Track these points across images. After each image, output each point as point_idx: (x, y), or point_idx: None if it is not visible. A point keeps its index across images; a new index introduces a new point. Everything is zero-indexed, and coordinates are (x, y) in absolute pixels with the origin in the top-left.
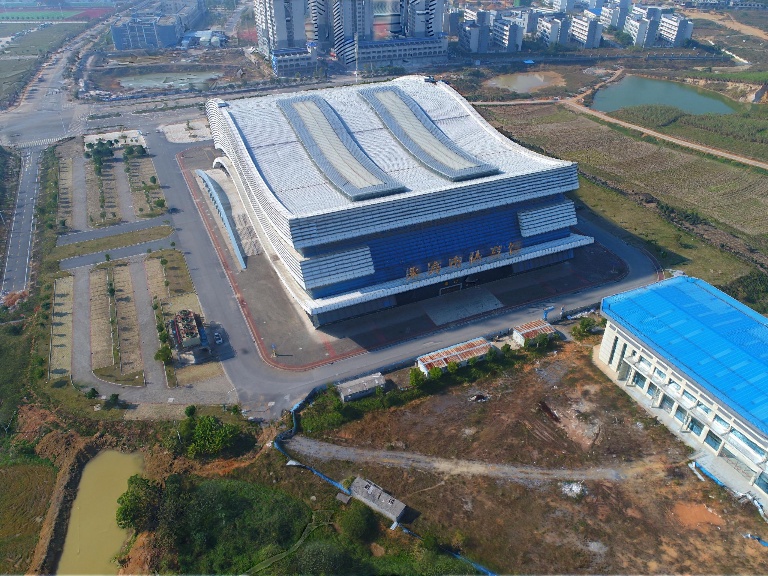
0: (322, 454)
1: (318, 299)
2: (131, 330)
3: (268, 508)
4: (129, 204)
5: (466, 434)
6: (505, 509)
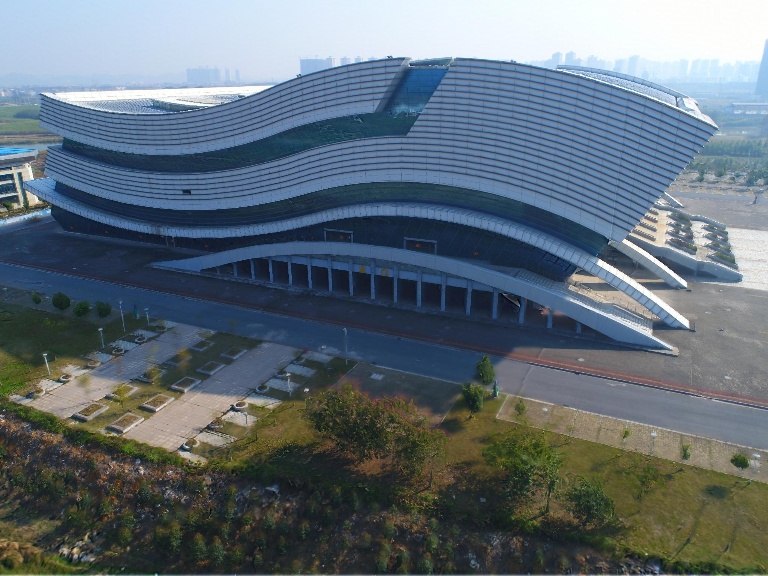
0: None
1: None
2: None
3: None
4: None
5: None
6: None
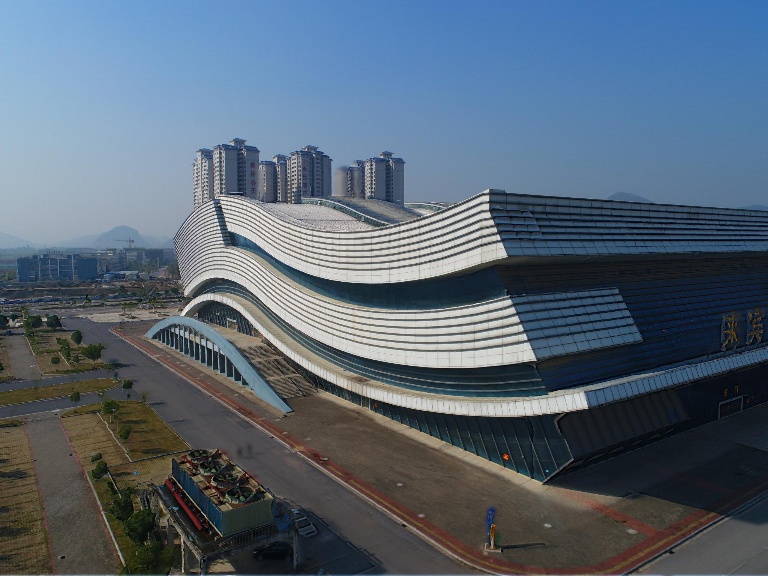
0: None
1: None
2: (22, 532)
3: None
4: (30, 364)
5: None
6: None
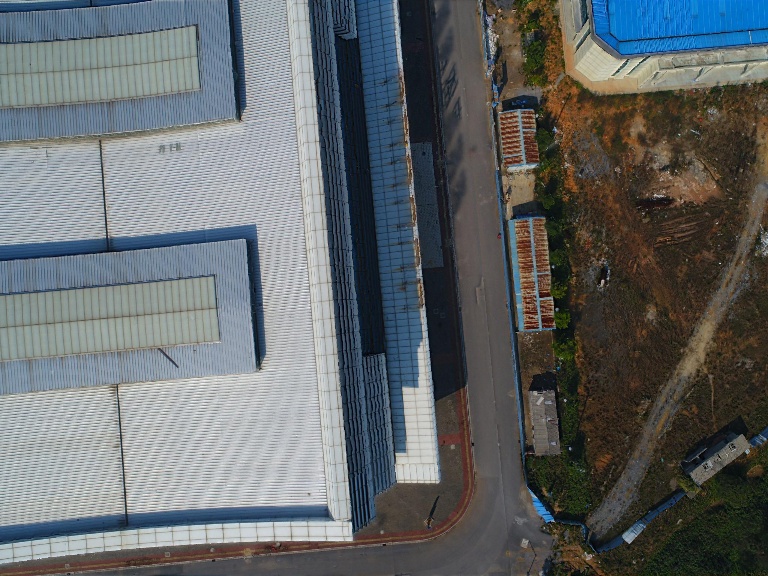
0: (627, 499)
1: (398, 458)
2: None
3: (683, 575)
4: None
5: (653, 320)
6: (765, 327)
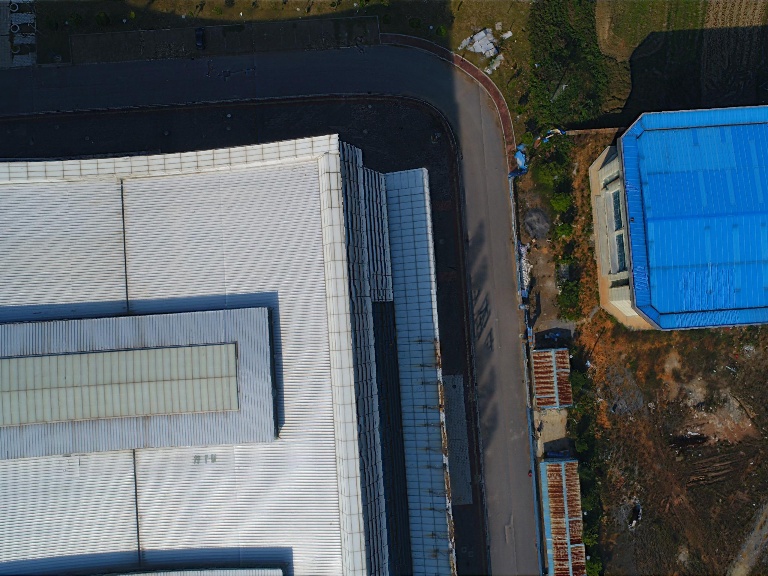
0: None
1: None
2: None
3: None
4: None
5: (685, 561)
6: None
